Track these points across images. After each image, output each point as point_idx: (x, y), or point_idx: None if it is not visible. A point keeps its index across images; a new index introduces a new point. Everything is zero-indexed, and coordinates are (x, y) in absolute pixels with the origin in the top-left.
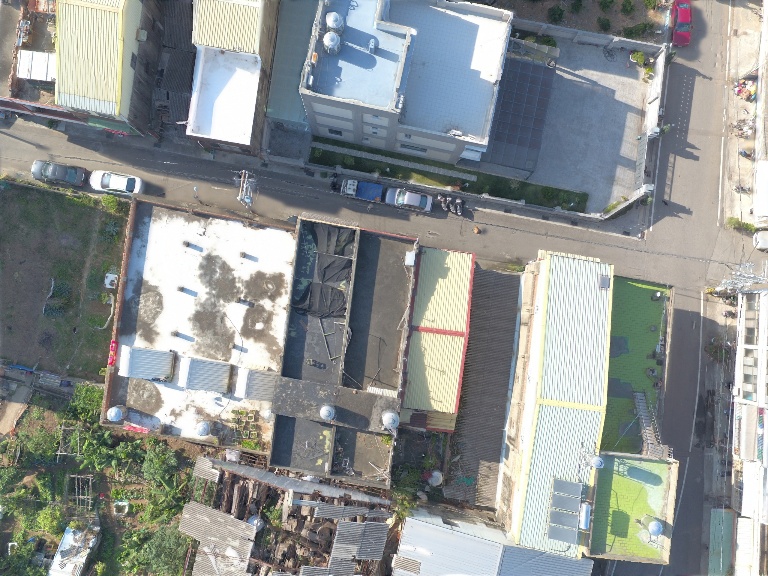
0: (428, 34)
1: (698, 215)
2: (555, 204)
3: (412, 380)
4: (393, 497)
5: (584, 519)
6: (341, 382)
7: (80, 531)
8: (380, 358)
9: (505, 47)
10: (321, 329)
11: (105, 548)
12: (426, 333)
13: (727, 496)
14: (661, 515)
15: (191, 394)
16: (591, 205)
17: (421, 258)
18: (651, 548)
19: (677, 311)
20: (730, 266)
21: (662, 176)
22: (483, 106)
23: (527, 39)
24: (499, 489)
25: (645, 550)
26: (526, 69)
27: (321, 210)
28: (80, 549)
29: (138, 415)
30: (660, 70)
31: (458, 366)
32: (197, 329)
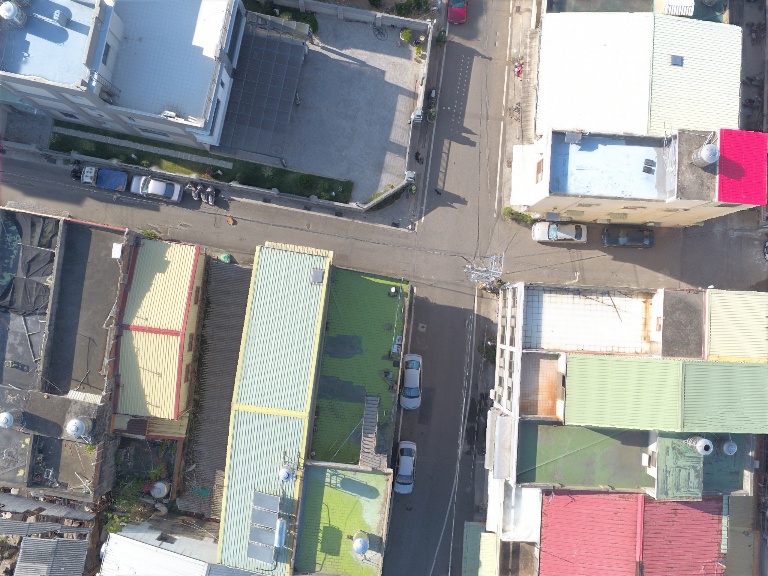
0: (146, 7)
1: (473, 205)
2: (317, 193)
3: (125, 383)
4: (132, 509)
5: (277, 536)
6: (41, 386)
7: None
8: (89, 359)
9: (228, 21)
10: (24, 328)
11: None
12: (138, 332)
13: None
14: (377, 531)
15: None
16: (357, 194)
17: (139, 251)
18: (365, 567)
19: (448, 308)
20: (467, 259)
21: (436, 163)
22: (205, 85)
23: (282, 15)
24: None
25: (359, 569)
26: (272, 47)
27: (63, 200)
28: None
29: None
30: None
31: (175, 368)
32: None
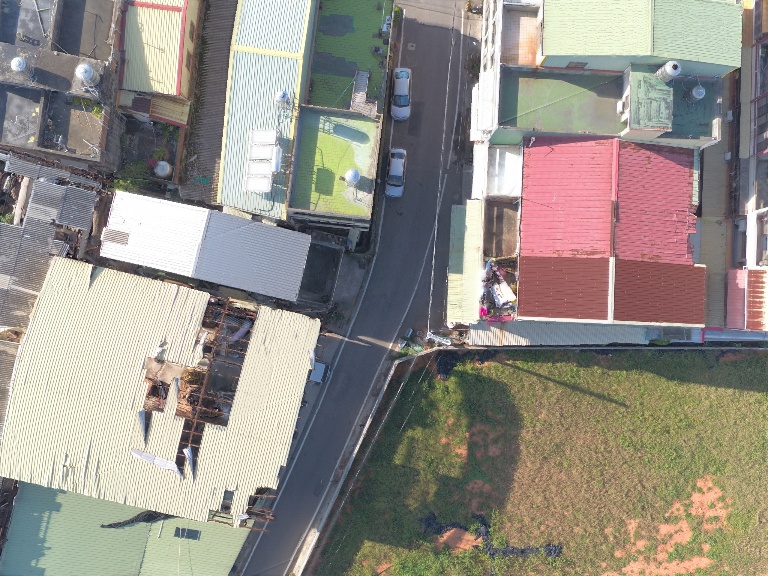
0: None
1: None
2: None
3: (130, 59)
4: None
5: (274, 161)
6: None
7: None
8: (96, 35)
9: None
10: (35, 5)
11: None
12: (142, 8)
13: None
14: (368, 174)
15: None
16: None
17: None
18: (357, 207)
19: (436, 29)
20: None
21: None
22: None
23: None
24: None
25: (351, 209)
26: None
27: None
28: None
29: None
30: None
31: (177, 44)
32: None
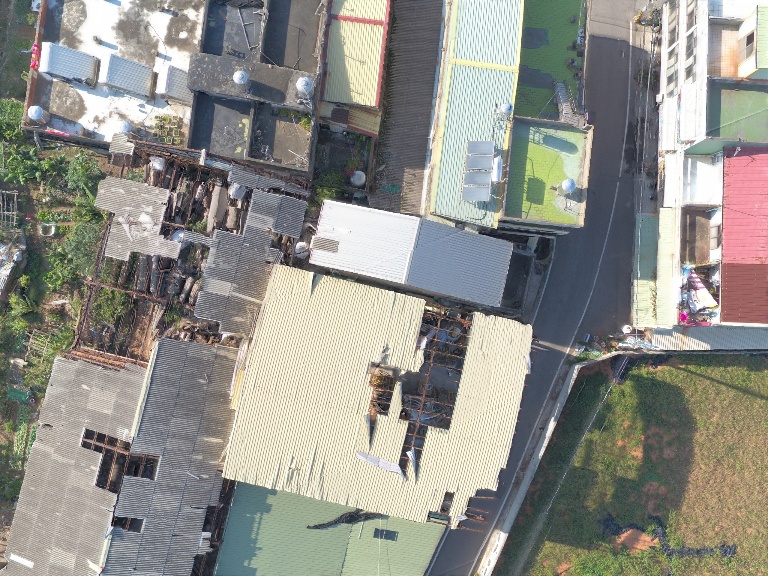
0: None
1: None
2: None
3: (332, 71)
4: None
5: (496, 171)
6: None
7: (4, 244)
8: (299, 48)
9: None
10: (240, 19)
11: (31, 268)
12: (345, 22)
13: (654, 209)
14: (577, 183)
15: (114, 101)
16: None
17: None
18: (567, 215)
19: (606, 40)
20: None
21: None
22: None
23: None
24: (424, 195)
25: (561, 217)
26: None
27: None
28: (4, 262)
29: (61, 121)
30: None
31: (378, 56)
32: (121, 37)
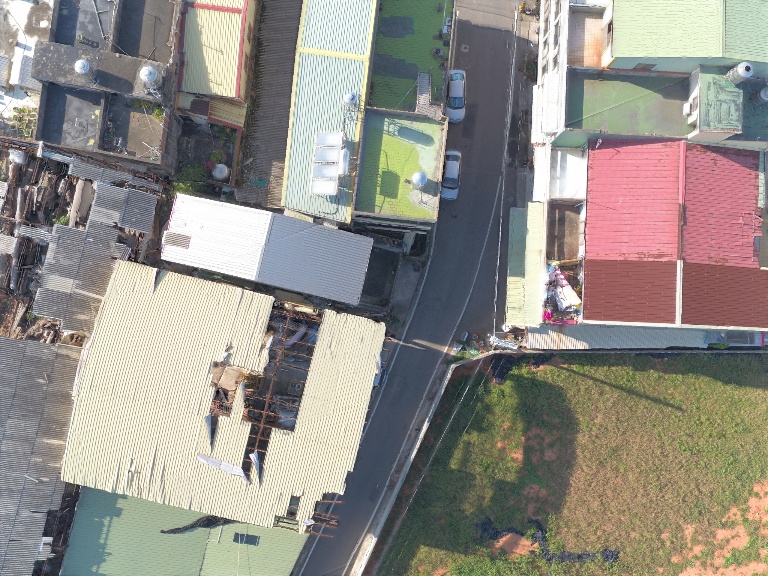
0: None
1: None
2: None
3: (190, 61)
4: None
5: (342, 164)
6: None
7: None
8: (155, 37)
9: None
10: (94, 7)
11: None
12: (202, 10)
13: None
14: (433, 176)
15: None
16: None
17: None
18: (422, 209)
19: (490, 30)
20: None
21: None
22: None
23: None
24: None
25: (416, 212)
26: None
27: None
28: None
29: None
30: None
31: (237, 46)
32: None
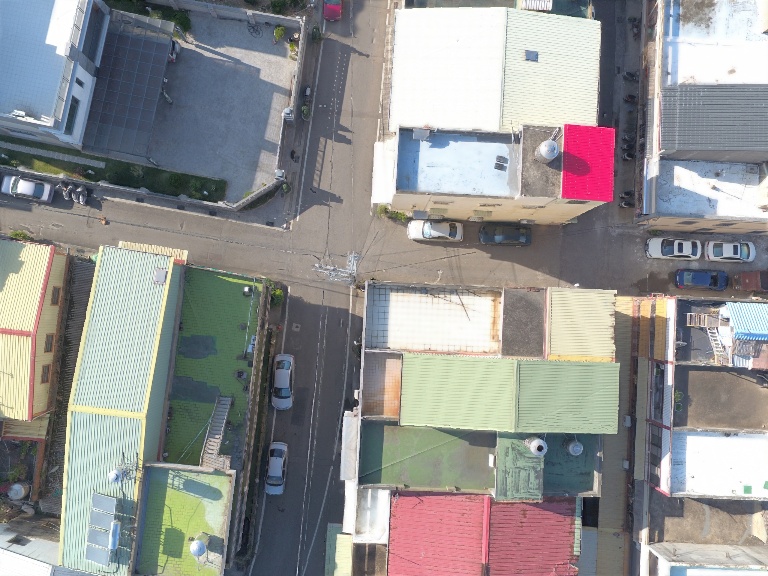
0: None
1: (349, 203)
2: (190, 192)
3: None
4: None
5: (111, 538)
6: None
7: None
8: None
9: (80, 19)
10: None
11: None
12: None
13: None
14: (220, 533)
15: None
16: (231, 193)
17: None
18: (208, 569)
19: (323, 308)
20: (319, 258)
21: (311, 161)
22: (58, 84)
23: (152, 13)
24: None
25: (201, 571)
26: (137, 45)
27: None
28: None
29: None
30: (299, 46)
31: (27, 369)
32: None
